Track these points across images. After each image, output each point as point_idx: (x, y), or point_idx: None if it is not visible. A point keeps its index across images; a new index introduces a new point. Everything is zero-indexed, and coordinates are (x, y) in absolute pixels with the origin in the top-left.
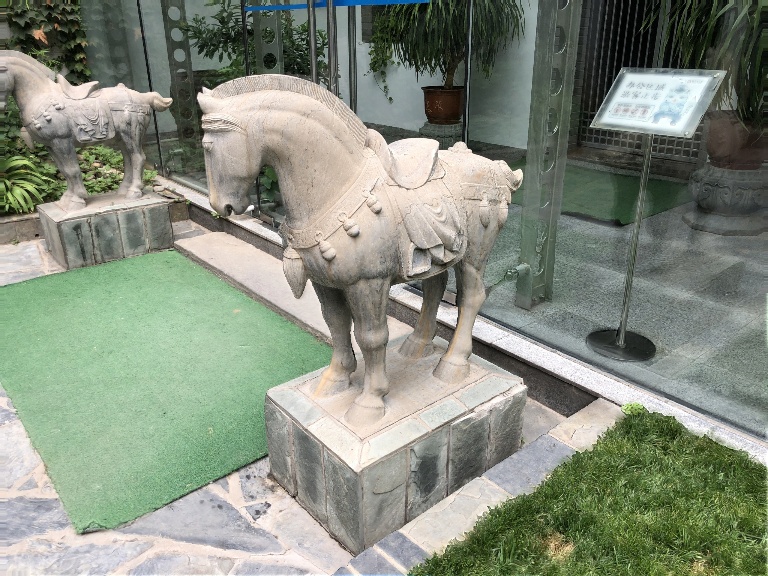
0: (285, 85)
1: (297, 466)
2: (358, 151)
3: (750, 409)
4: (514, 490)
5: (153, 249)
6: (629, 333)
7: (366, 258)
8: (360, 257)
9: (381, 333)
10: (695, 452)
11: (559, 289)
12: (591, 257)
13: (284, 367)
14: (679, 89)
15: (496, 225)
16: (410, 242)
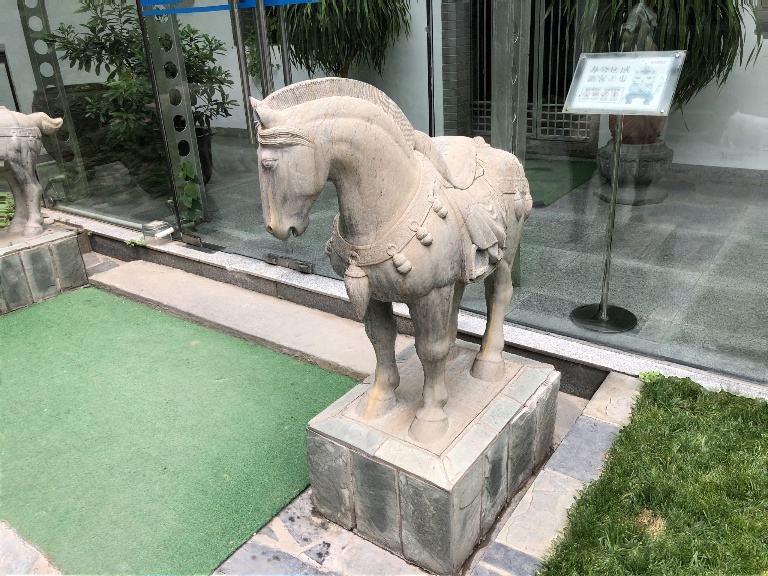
0: (344, 90)
1: (357, 497)
2: (413, 155)
3: (740, 359)
4: (582, 476)
5: (65, 289)
6: None
7: (440, 266)
8: (435, 266)
9: (446, 342)
10: (720, 407)
11: None
12: (533, 238)
13: (275, 394)
14: (645, 70)
15: (523, 217)
16: (472, 244)
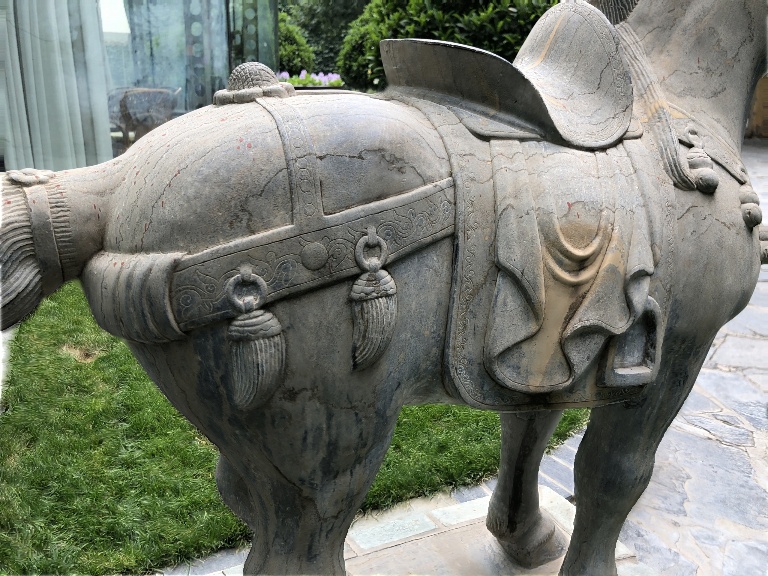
0: None
1: None
2: None
3: None
4: None
5: None
6: None
7: None
8: None
9: None
10: None
11: None
12: None
13: None
14: None
15: None
16: None
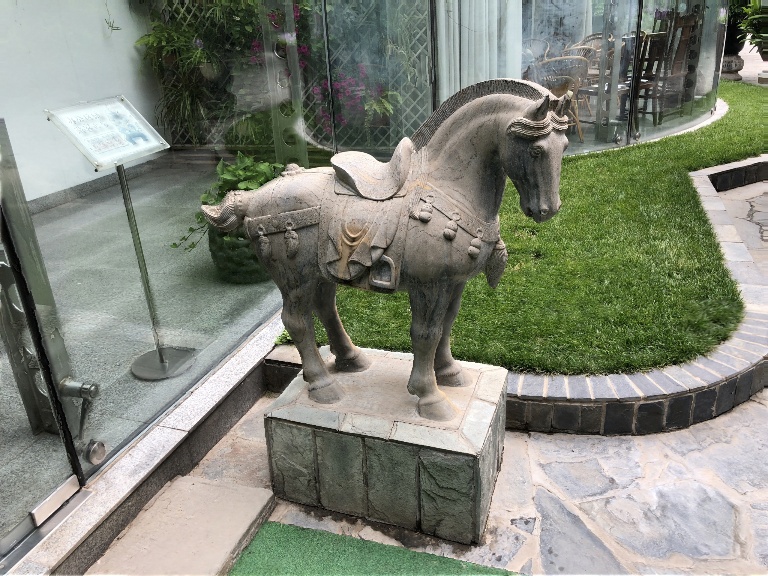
0: None
1: None
2: None
3: (244, 312)
4: None
5: None
6: (137, 362)
7: None
8: None
9: None
10: None
11: (3, 426)
12: None
13: None
14: None
15: None
16: None
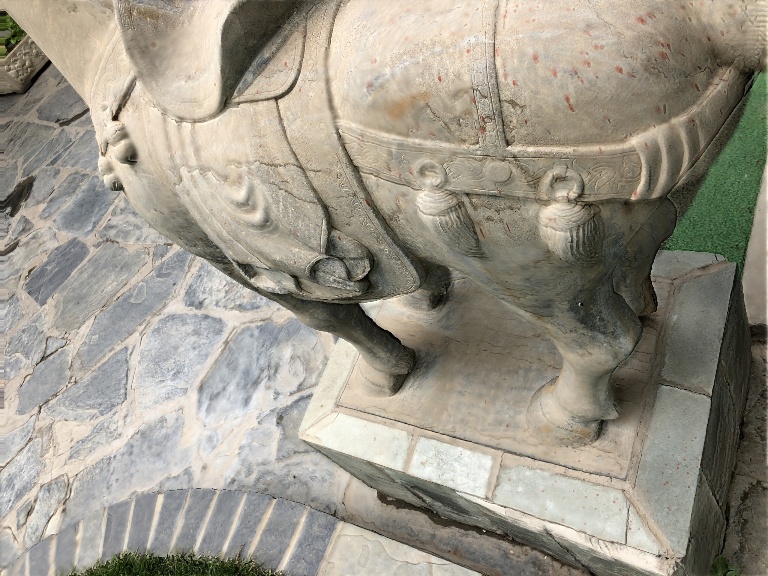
0: None
1: None
2: (91, 1)
3: None
4: None
5: None
6: None
7: None
8: None
9: (304, 318)
10: None
11: None
12: None
13: None
14: None
15: (549, 255)
16: None
